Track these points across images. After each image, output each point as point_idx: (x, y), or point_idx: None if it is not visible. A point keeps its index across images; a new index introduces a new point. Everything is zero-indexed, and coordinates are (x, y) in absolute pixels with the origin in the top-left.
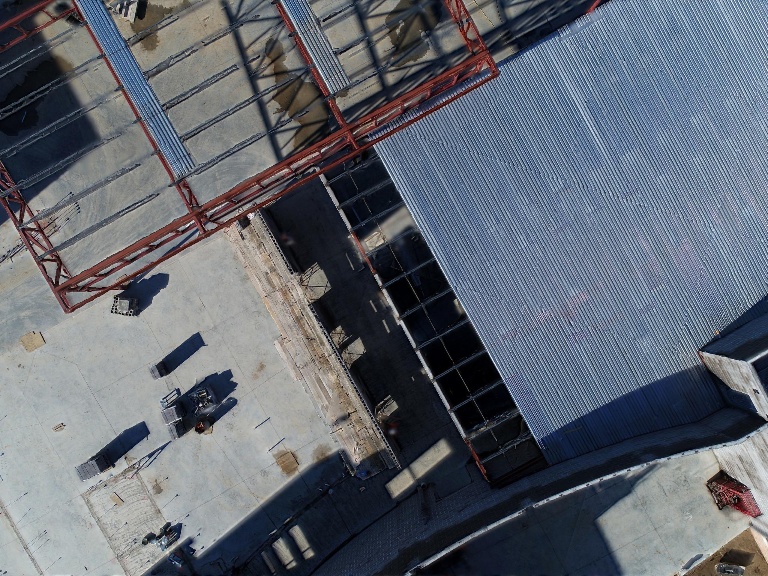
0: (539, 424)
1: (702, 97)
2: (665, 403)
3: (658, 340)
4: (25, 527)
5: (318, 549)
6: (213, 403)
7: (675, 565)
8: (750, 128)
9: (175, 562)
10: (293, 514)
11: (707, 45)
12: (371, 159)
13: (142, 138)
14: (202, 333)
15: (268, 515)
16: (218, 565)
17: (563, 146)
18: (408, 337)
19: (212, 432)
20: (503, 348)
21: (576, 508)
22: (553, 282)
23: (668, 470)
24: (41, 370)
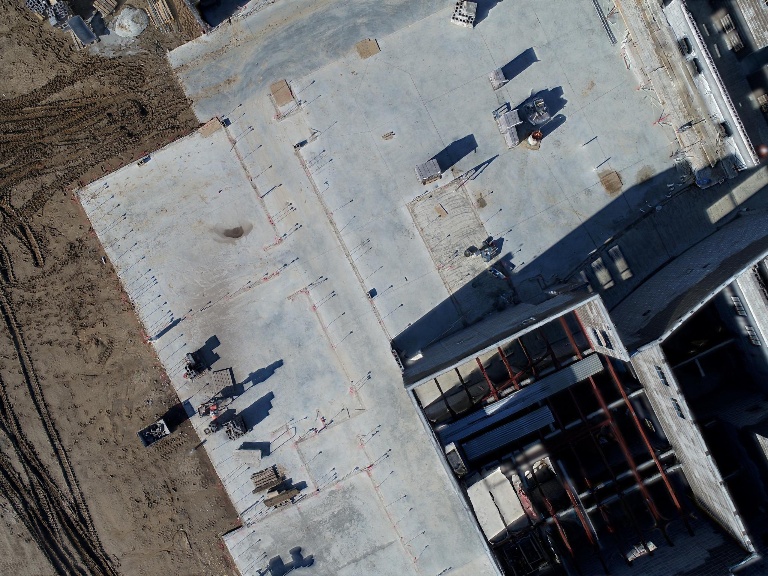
0: None
1: None
2: None
3: None
4: (349, 234)
5: (636, 271)
6: (548, 114)
7: None
8: None
9: (499, 273)
10: (614, 234)
11: None
12: None
13: None
14: (535, 48)
15: (589, 234)
16: (537, 281)
17: None
18: None
19: (539, 148)
20: None
21: None
22: None
23: None
24: (374, 78)
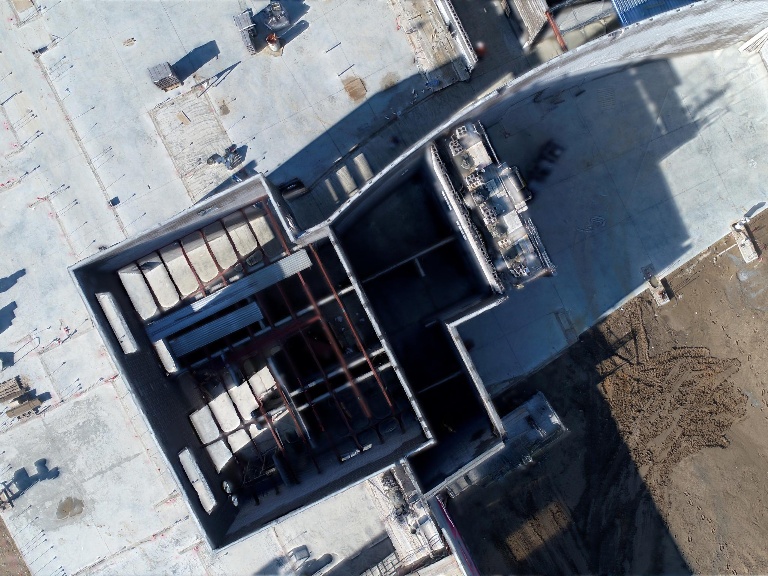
0: None
1: None
2: None
3: None
4: (90, 142)
5: None
6: (286, 18)
7: (737, 212)
8: None
9: (240, 179)
10: (359, 142)
11: None
12: None
13: None
14: None
15: (334, 142)
16: None
17: None
18: None
19: (282, 54)
20: None
21: (641, 149)
22: None
23: (735, 115)
24: None
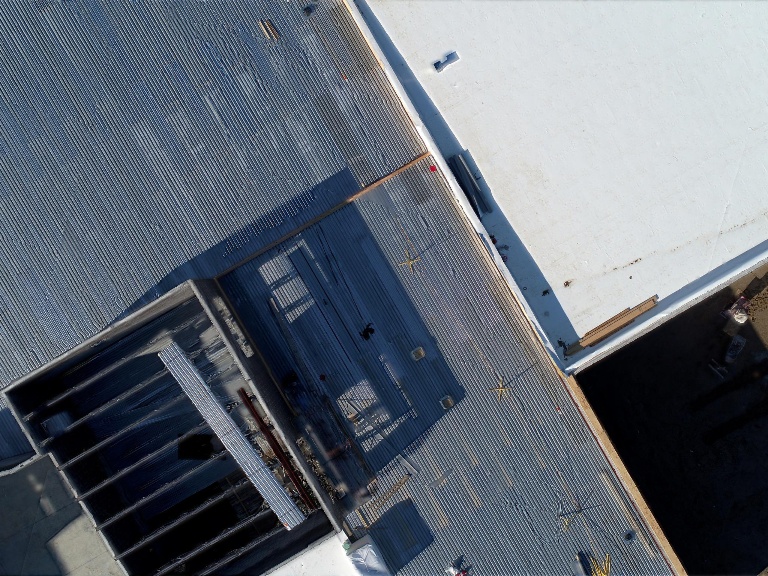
0: None
1: (39, 122)
2: (16, 430)
3: (6, 367)
4: None
5: None
6: None
7: None
8: (90, 152)
9: None
10: None
11: (42, 70)
12: None
13: None
14: None
15: None
16: None
17: None
18: None
19: None
20: None
21: (27, 532)
22: None
23: None
24: None
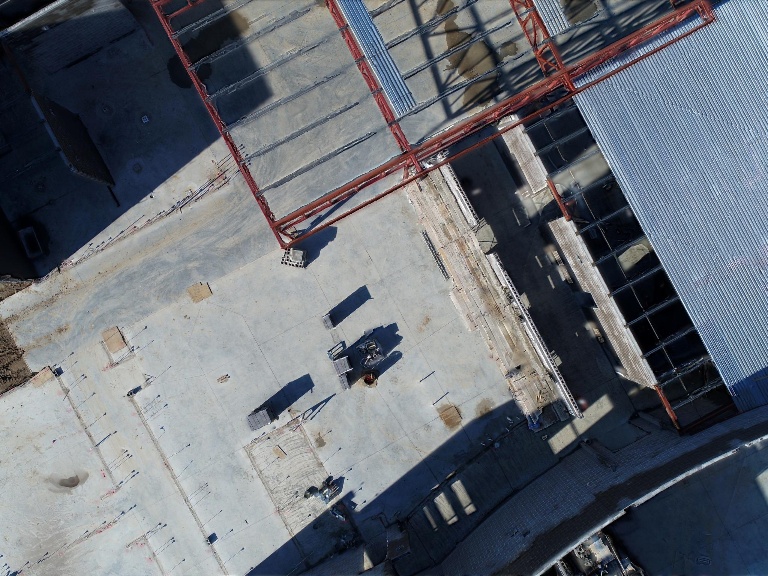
0: (730, 371)
1: None
2: None
3: None
4: (186, 479)
5: (480, 505)
6: (381, 355)
7: None
8: None
9: (339, 516)
10: (456, 469)
11: None
12: (568, 107)
13: (314, 92)
14: (369, 286)
15: (431, 470)
16: (380, 520)
17: (755, 98)
18: (602, 283)
19: (376, 385)
20: (695, 295)
21: (737, 466)
22: (744, 231)
23: None
24: (207, 321)
